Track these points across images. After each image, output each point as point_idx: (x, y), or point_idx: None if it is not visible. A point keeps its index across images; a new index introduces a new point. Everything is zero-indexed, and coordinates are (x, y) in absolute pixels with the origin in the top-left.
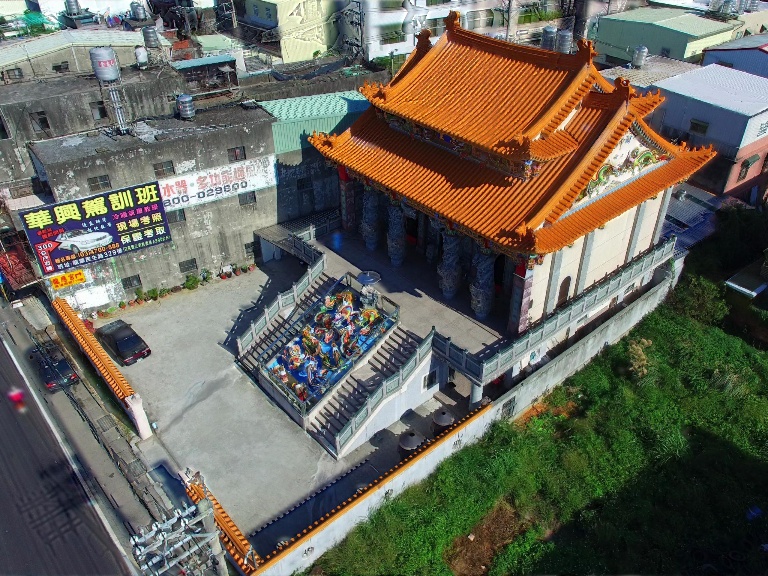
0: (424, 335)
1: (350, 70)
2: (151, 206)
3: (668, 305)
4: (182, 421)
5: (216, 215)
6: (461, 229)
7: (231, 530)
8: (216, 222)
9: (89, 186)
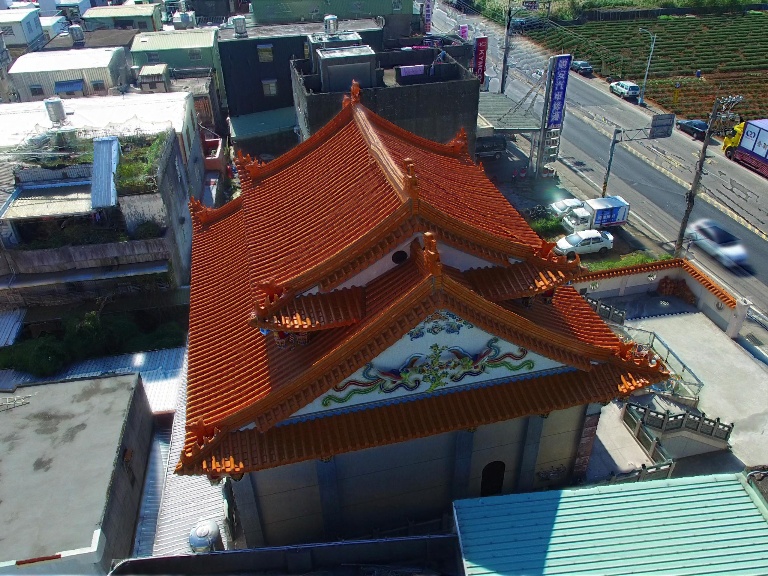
0: None
1: None
2: None
3: None
4: None
5: None
6: None
7: (704, 276)
8: None
9: None
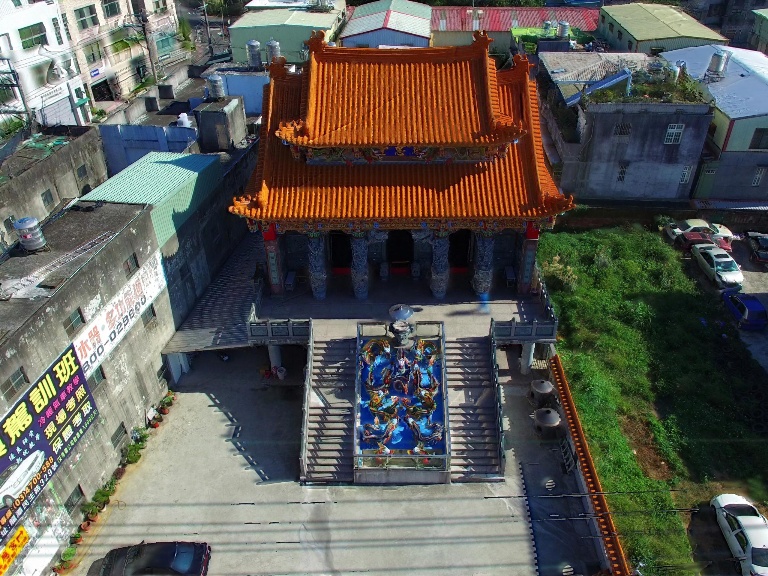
0: (473, 334)
1: (34, 142)
2: (72, 382)
3: None
4: (342, 574)
5: (129, 354)
6: (458, 226)
7: None
8: (130, 363)
9: (3, 397)
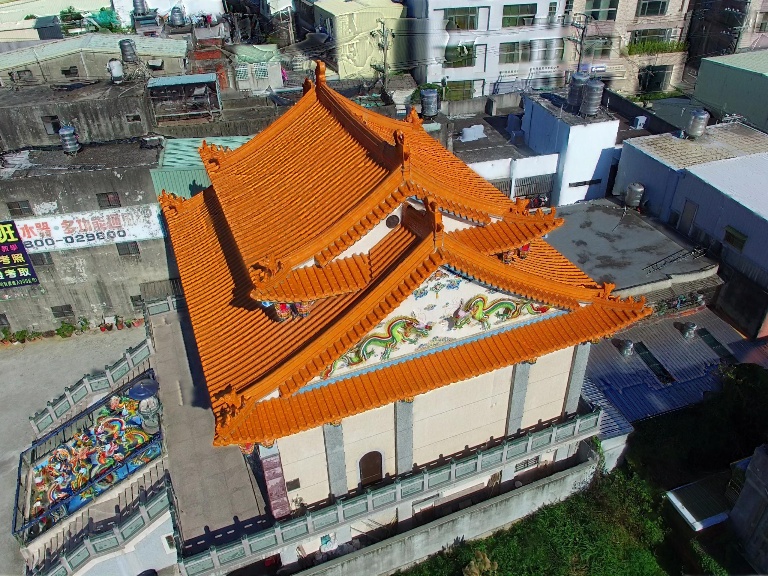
0: (178, 482)
1: None
2: (10, 246)
3: (588, 497)
4: None
5: (91, 262)
6: None
7: None
8: (92, 270)
9: None
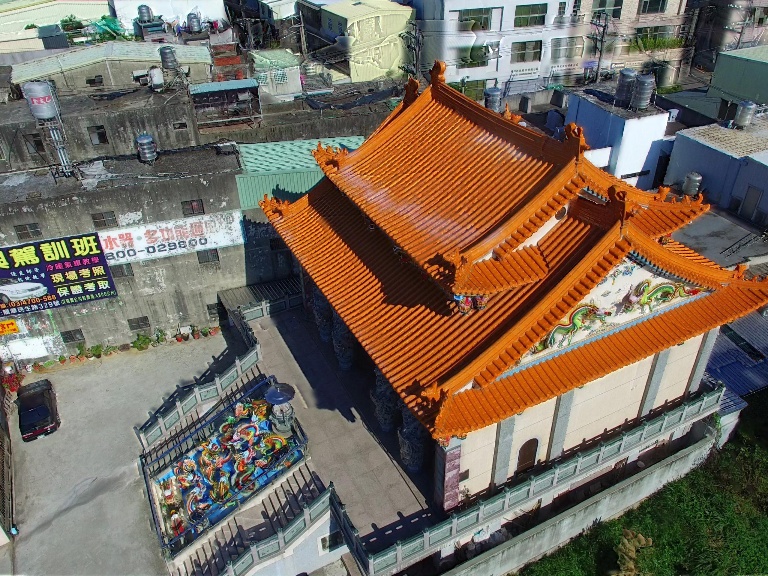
0: None
1: (397, 101)
2: (91, 258)
3: (706, 472)
4: (47, 529)
5: (170, 272)
6: None
7: None
8: (171, 279)
9: (17, 233)
